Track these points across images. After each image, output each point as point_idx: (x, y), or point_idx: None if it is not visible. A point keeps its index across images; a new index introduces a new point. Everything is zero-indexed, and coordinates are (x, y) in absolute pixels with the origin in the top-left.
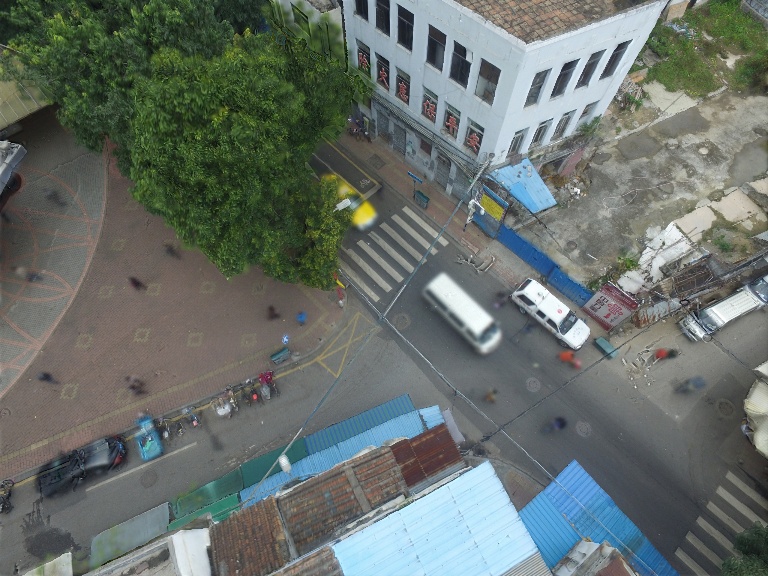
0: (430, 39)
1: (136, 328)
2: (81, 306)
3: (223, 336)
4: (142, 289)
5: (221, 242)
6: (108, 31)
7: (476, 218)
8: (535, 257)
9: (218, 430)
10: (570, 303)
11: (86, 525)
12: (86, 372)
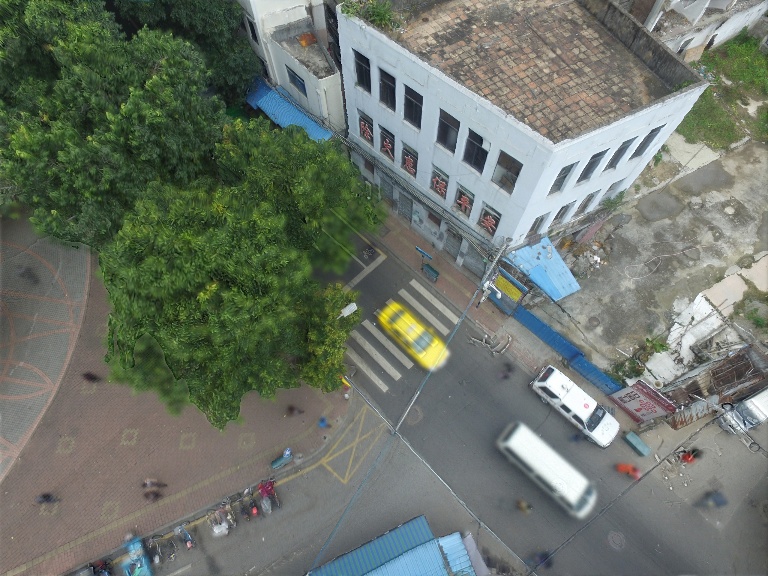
0: (441, 122)
1: (123, 429)
2: (62, 404)
3: (218, 436)
4: (129, 382)
5: (212, 391)
6: (82, 129)
7: (490, 294)
8: (556, 340)
9: (214, 549)
10: (595, 390)
11: None
12: (68, 482)
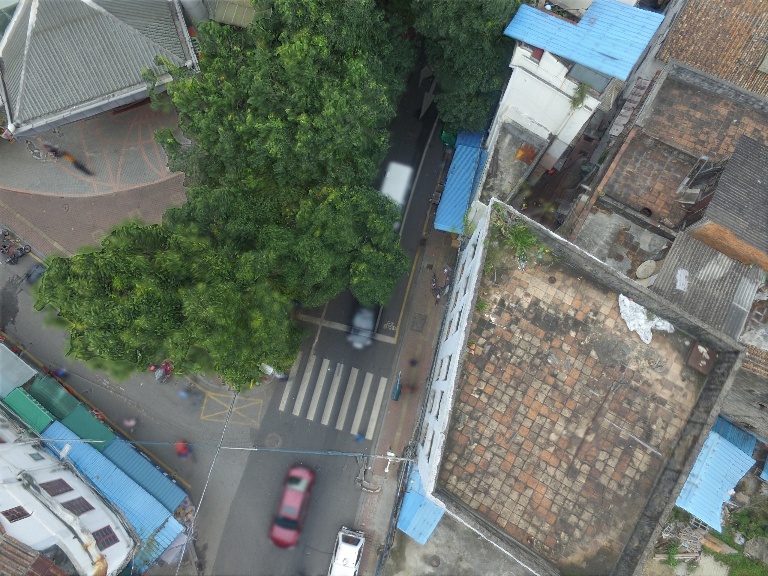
0: None
1: None
2: (158, 191)
3: None
4: None
5: None
6: None
7: None
8: None
9: None
10: None
11: (27, 317)
12: None
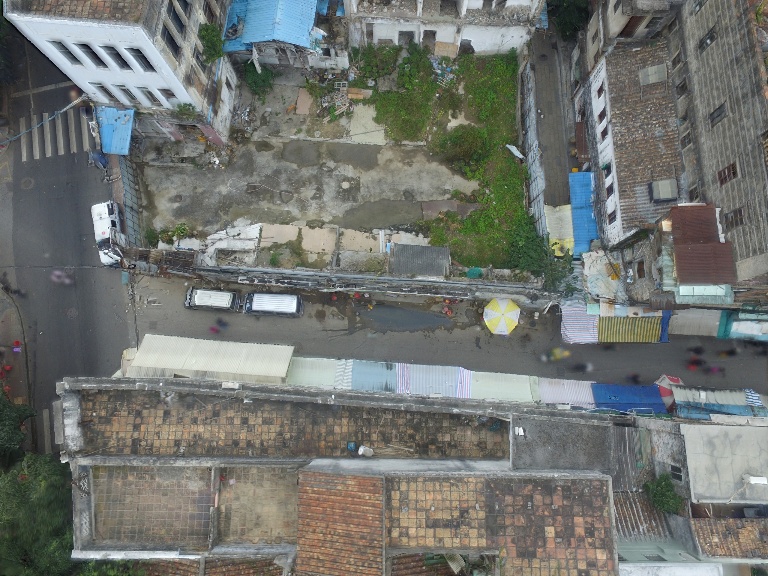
0: None
1: None
2: None
3: None
4: None
5: None
6: None
7: None
8: None
9: None
10: (139, 236)
11: None
12: None
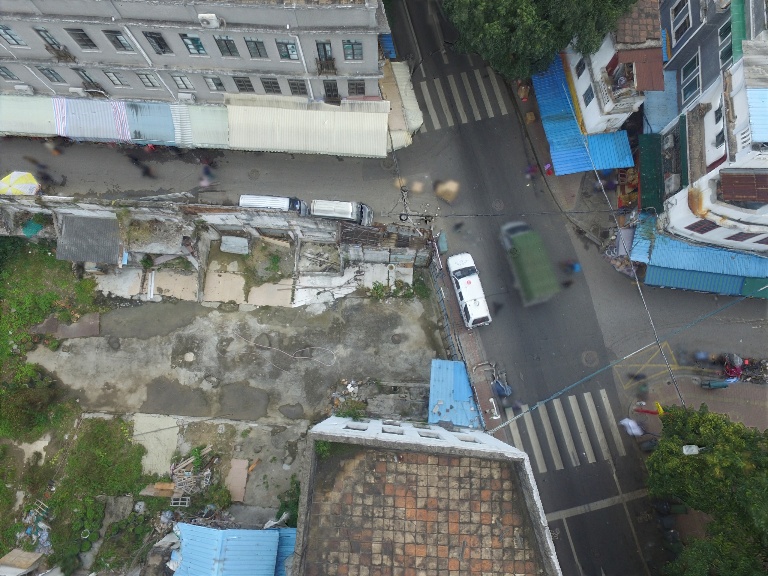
0: None
1: None
2: None
3: None
4: None
5: None
6: None
7: None
8: None
9: None
10: None
11: None
12: None
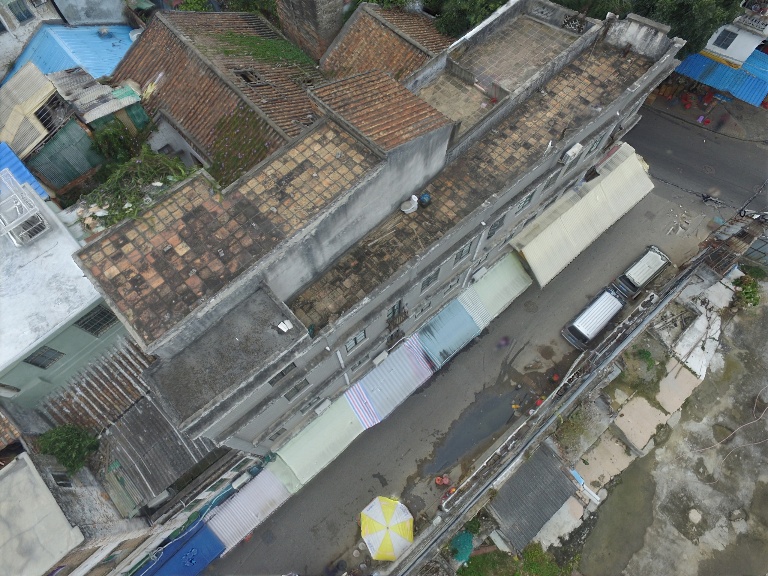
0: None
1: None
2: None
3: None
4: None
5: None
6: None
7: None
8: None
9: None
10: None
11: None
12: None
